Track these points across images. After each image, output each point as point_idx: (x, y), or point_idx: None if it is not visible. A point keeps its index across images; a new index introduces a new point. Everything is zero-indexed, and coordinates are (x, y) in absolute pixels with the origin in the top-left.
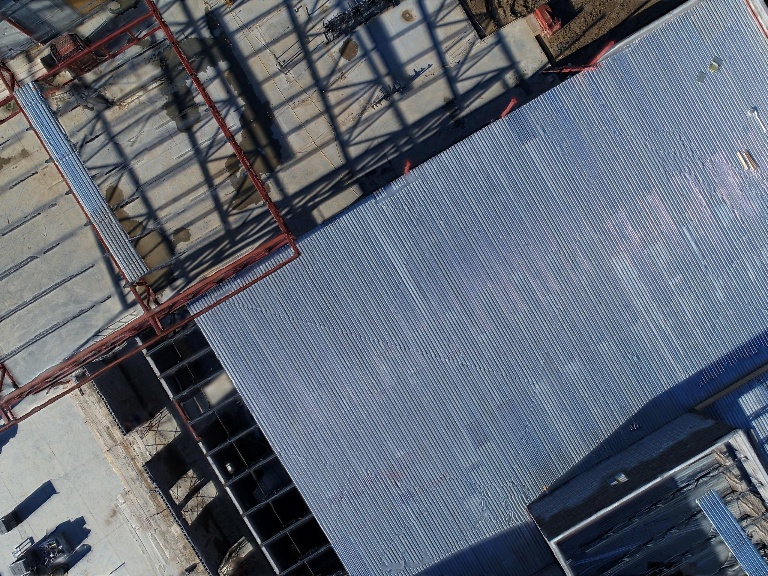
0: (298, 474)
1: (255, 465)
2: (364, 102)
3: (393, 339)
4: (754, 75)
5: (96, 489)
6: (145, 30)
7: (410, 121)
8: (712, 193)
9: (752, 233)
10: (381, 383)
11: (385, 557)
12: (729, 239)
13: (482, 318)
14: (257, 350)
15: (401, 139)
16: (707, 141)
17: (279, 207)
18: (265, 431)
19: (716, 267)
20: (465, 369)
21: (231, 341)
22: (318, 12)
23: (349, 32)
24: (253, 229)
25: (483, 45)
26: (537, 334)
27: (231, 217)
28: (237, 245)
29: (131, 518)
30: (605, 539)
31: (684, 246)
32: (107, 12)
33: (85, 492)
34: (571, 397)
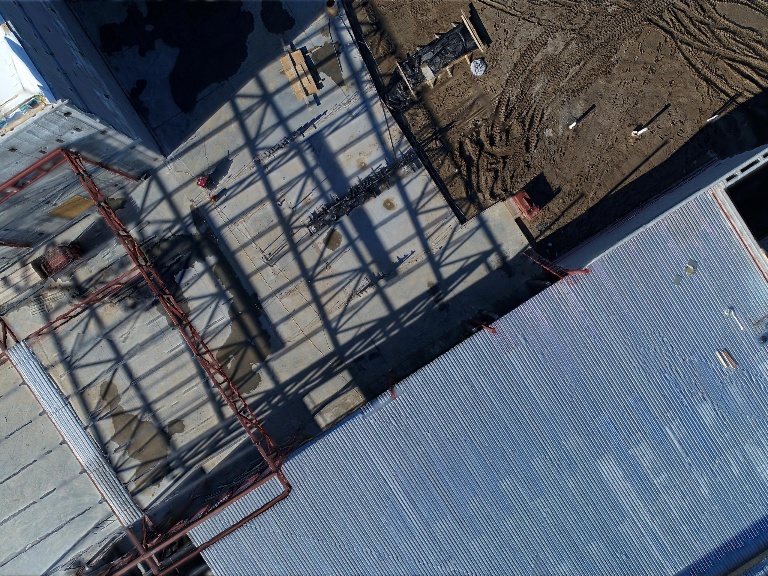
0: None
1: None
2: (349, 290)
3: (385, 549)
4: (729, 275)
5: None
6: (133, 229)
7: (395, 307)
8: (693, 386)
9: (734, 429)
10: None
11: None
12: (711, 436)
13: (472, 525)
14: (253, 566)
15: (387, 325)
16: (686, 342)
17: (270, 395)
18: None
19: (700, 464)
20: (457, 575)
21: (227, 558)
22: (301, 205)
23: None
24: None
25: (464, 230)
26: (526, 538)
27: (224, 407)
28: (231, 434)
29: None
30: None
31: (667, 445)
32: (95, 213)
33: None
34: None
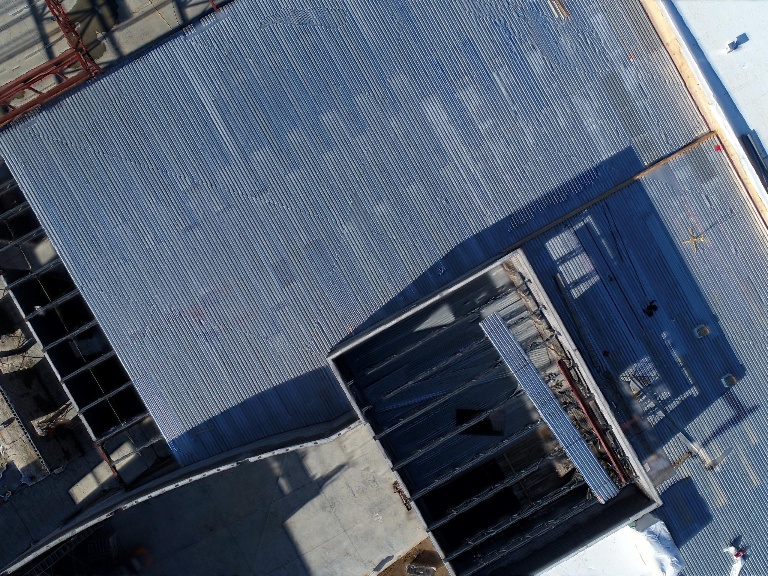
0: (100, 309)
1: (57, 299)
2: None
3: (199, 175)
4: None
5: None
6: None
7: None
8: None
9: (562, 80)
10: (187, 220)
11: None
12: (539, 86)
13: (290, 157)
14: (61, 183)
15: None
16: None
17: None
18: (67, 265)
19: (526, 113)
20: (272, 208)
21: (35, 173)
22: None
23: None
24: None
25: None
26: (345, 174)
27: (66, 75)
28: None
29: None
30: (387, 361)
31: (494, 91)
32: None
33: None
34: (379, 239)
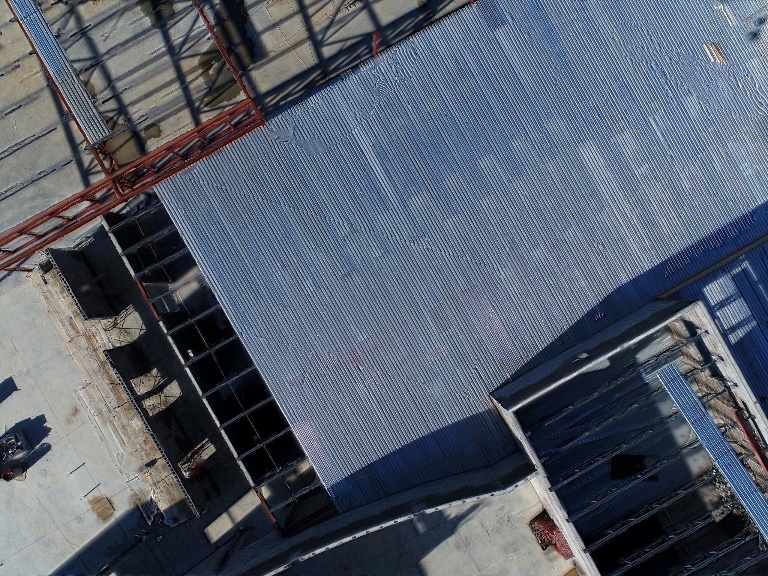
0: (259, 355)
1: (216, 345)
2: (338, 3)
3: (358, 221)
4: None
5: (58, 386)
6: None
7: (383, 23)
8: None
9: (718, 125)
10: (345, 265)
11: (273, 123)
12: (695, 130)
13: (448, 202)
14: (221, 229)
15: None
16: (674, 33)
17: None
18: (227, 311)
19: (682, 158)
20: (430, 253)
21: (195, 219)
22: None
23: None
24: (224, 127)
25: None
26: (503, 220)
27: (202, 114)
28: None
29: (90, 404)
30: (565, 412)
31: (650, 136)
32: None
33: (47, 389)
34: (536, 284)
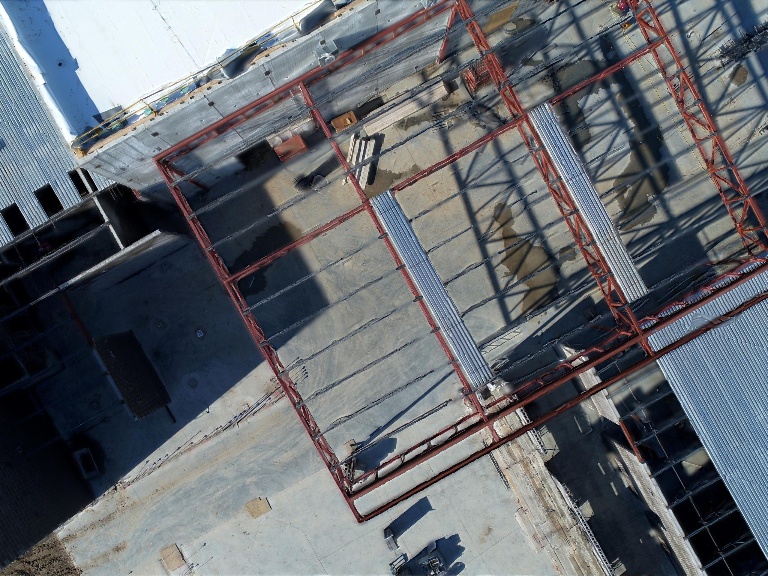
0: (742, 498)
1: (699, 487)
2: (752, 127)
3: None
4: None
5: (472, 506)
6: (540, 51)
7: None
8: None
9: None
10: None
11: None
12: None
13: None
14: (705, 372)
15: None
16: None
17: (664, 228)
18: (711, 453)
19: None
20: None
21: (680, 362)
22: (709, 38)
23: (739, 58)
24: (638, 250)
25: None
26: None
27: None
28: None
29: (551, 538)
30: None
31: None
32: (503, 32)
33: (461, 509)
34: None
